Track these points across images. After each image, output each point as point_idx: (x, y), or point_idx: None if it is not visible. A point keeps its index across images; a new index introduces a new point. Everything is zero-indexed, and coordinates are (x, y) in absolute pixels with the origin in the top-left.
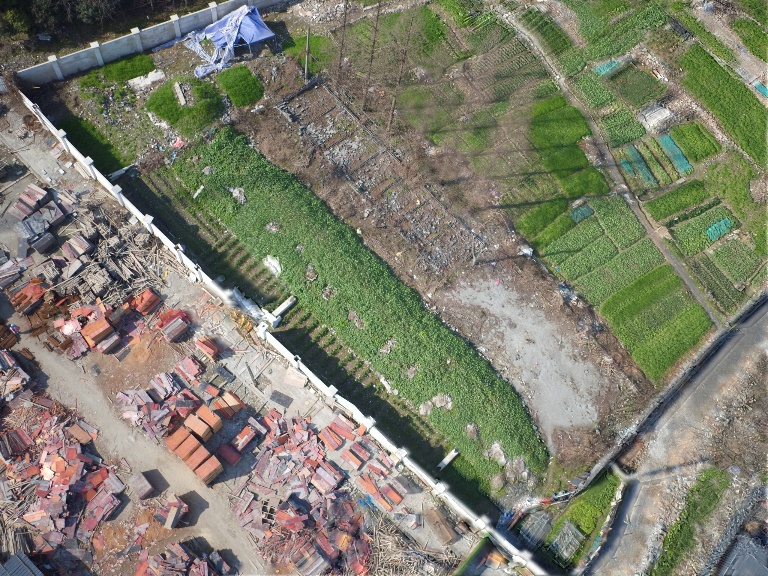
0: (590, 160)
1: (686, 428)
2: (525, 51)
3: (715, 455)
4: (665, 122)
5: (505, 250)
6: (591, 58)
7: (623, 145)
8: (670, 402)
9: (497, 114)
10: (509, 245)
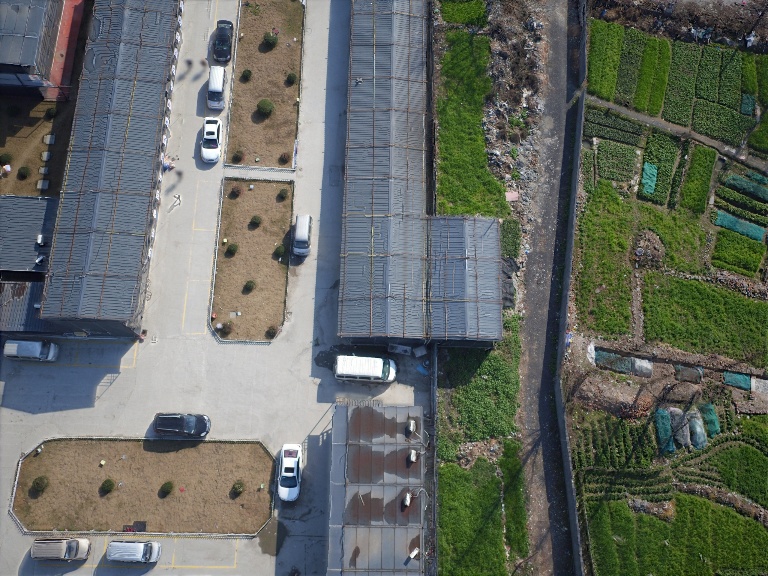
0: None
1: (554, 6)
2: None
3: (525, 2)
4: None
5: (764, 28)
6: None
7: None
8: (577, 13)
9: None
10: (766, 33)
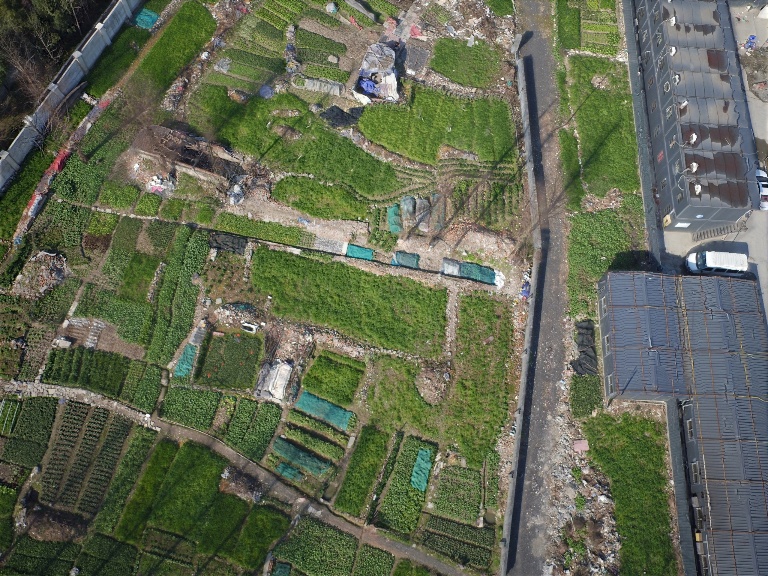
0: (247, 499)
1: None
2: (90, 409)
3: None
4: (293, 382)
5: None
6: (168, 360)
7: (269, 447)
8: None
9: (110, 529)
10: None
